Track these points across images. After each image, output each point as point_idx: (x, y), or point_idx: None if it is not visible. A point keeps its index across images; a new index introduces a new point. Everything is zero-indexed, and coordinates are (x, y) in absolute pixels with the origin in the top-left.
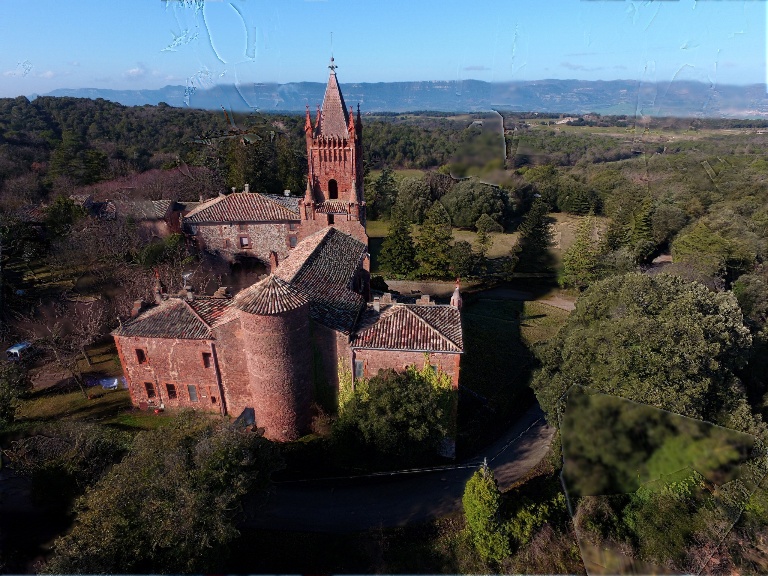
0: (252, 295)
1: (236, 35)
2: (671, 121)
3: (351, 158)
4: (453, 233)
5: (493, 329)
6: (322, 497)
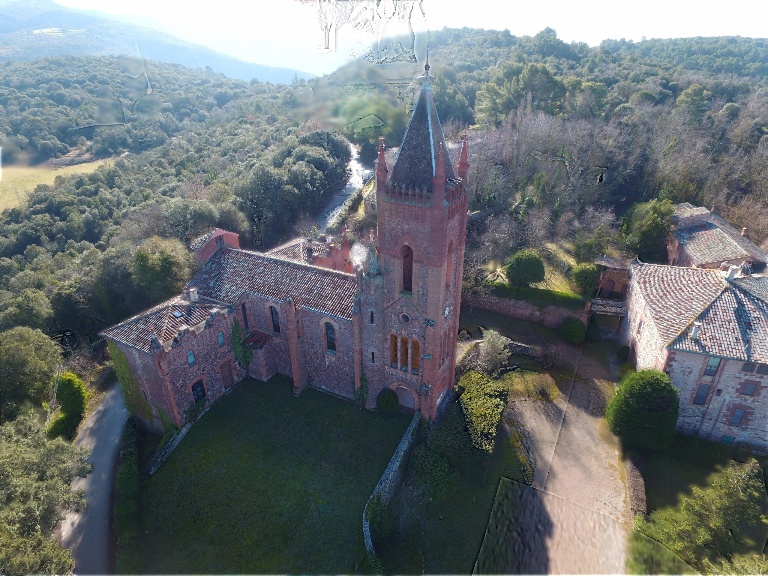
0: None
1: None
2: None
3: None
4: None
5: None
6: None
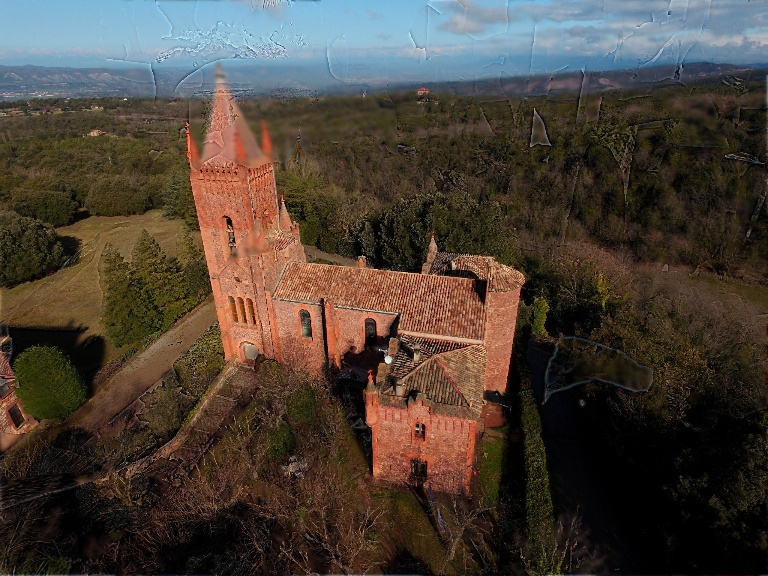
0: (507, 277)
1: None
2: None
3: (273, 179)
4: (18, 293)
5: None
6: (536, 379)
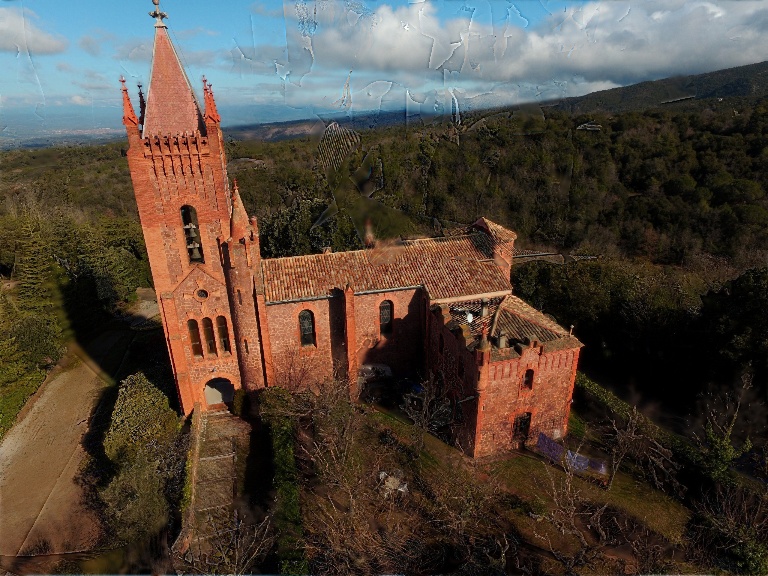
0: None
1: None
2: None
3: None
4: None
5: None
6: None
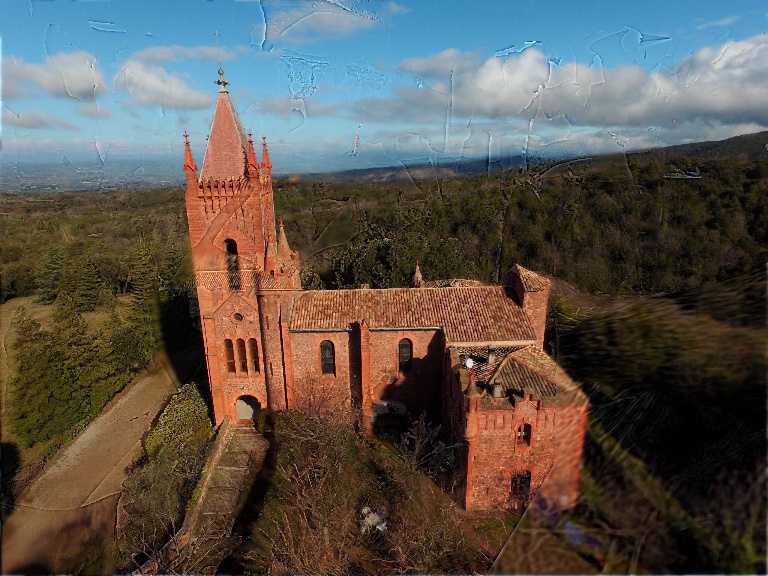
0: None
1: (244, 3)
2: (123, 171)
3: None
4: None
5: None
6: None
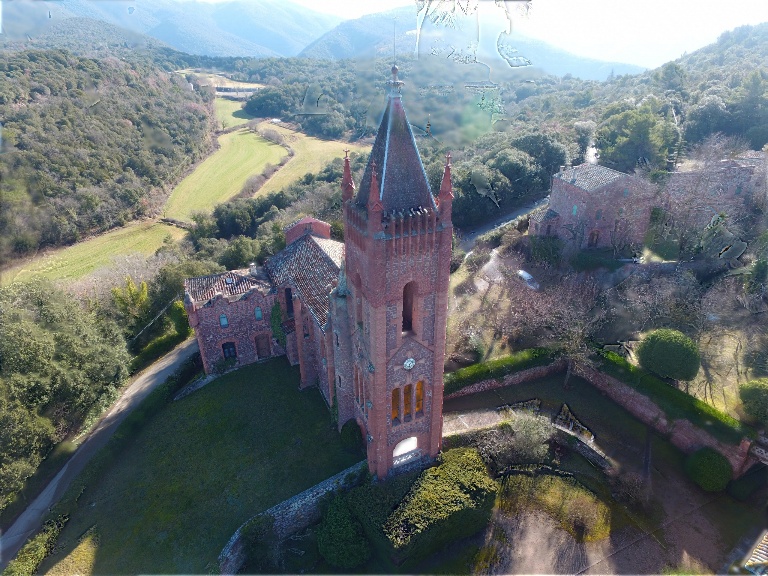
0: None
1: None
2: None
3: None
4: None
5: (146, 539)
6: None
